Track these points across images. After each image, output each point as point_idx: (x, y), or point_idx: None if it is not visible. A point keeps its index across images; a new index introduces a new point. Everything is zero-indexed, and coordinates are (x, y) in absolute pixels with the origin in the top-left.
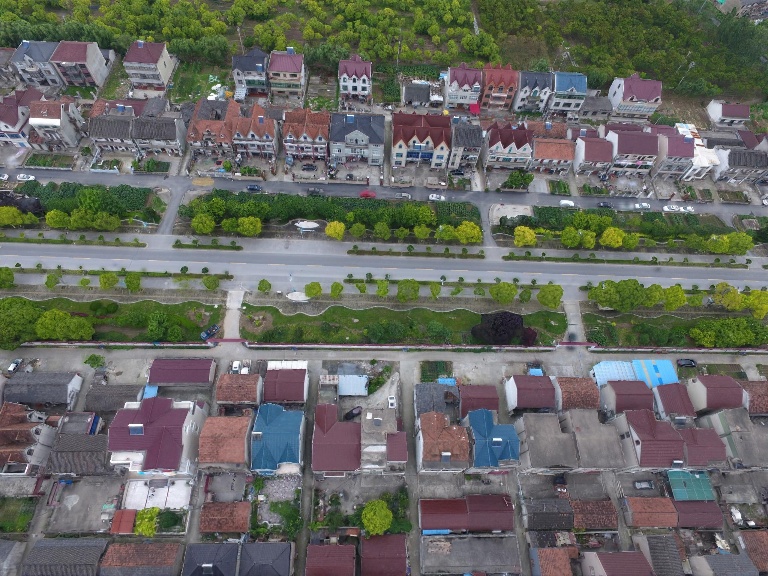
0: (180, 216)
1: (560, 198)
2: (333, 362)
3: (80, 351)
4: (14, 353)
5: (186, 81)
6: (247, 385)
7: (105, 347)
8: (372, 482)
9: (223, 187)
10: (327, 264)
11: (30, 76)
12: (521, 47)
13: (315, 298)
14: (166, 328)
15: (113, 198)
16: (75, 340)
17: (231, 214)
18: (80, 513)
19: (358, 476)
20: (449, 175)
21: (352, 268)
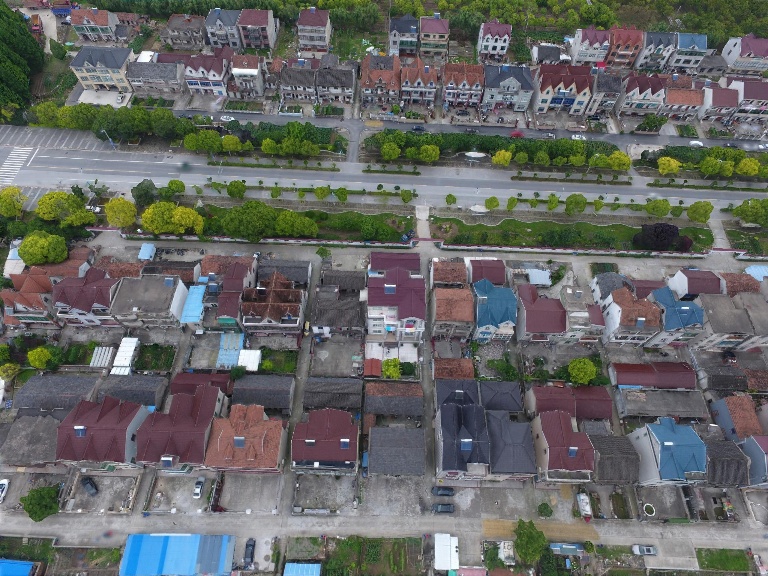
0: (367, 147)
1: (689, 140)
2: (515, 262)
3: (304, 248)
4: (252, 248)
5: (343, 44)
6: (459, 269)
7: (324, 245)
8: (566, 351)
9: (392, 128)
10: (495, 187)
11: (217, 39)
12: (633, 16)
13: (490, 213)
14: (376, 229)
15: (314, 130)
16: (302, 237)
17: (410, 145)
18: (332, 364)
19: (553, 346)
20: (588, 119)
21: (517, 191)
